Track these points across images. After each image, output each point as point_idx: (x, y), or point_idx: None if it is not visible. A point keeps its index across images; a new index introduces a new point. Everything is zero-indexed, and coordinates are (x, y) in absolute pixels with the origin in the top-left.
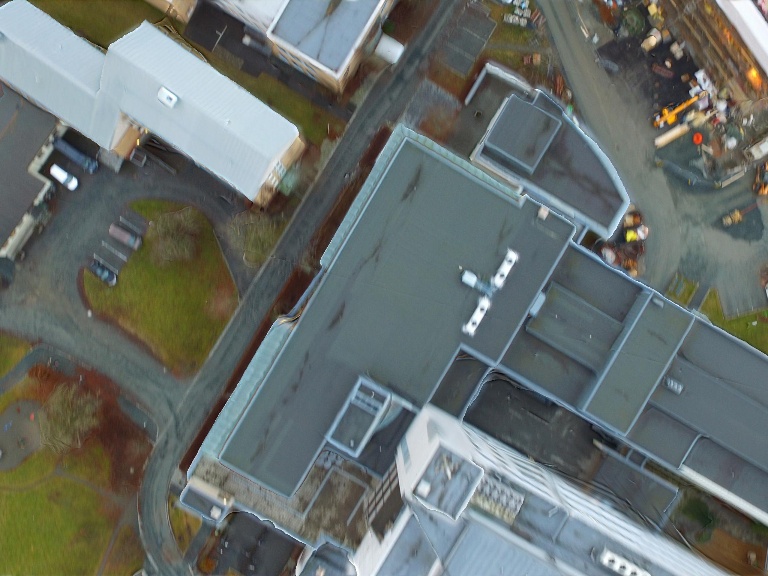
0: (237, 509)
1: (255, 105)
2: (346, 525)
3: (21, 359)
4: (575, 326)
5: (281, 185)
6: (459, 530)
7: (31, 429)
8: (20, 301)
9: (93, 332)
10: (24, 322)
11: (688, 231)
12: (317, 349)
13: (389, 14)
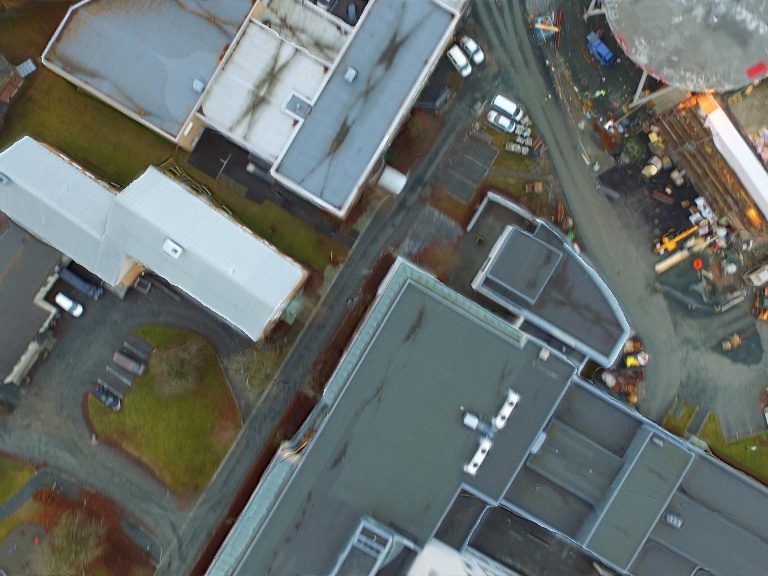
0: None
1: (259, 249)
2: None
3: (26, 483)
4: (575, 461)
5: (284, 314)
6: None
7: (35, 552)
8: (25, 425)
9: (97, 456)
10: (29, 446)
11: (688, 355)
12: (320, 488)
13: (392, 142)
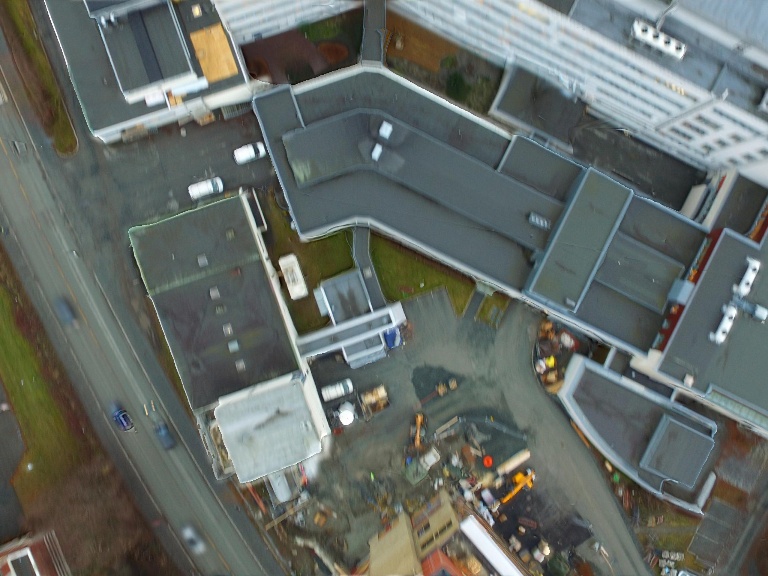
0: None
1: None
2: None
3: None
4: (636, 272)
5: None
6: None
7: None
8: None
9: None
10: None
11: (489, 371)
12: None
13: None
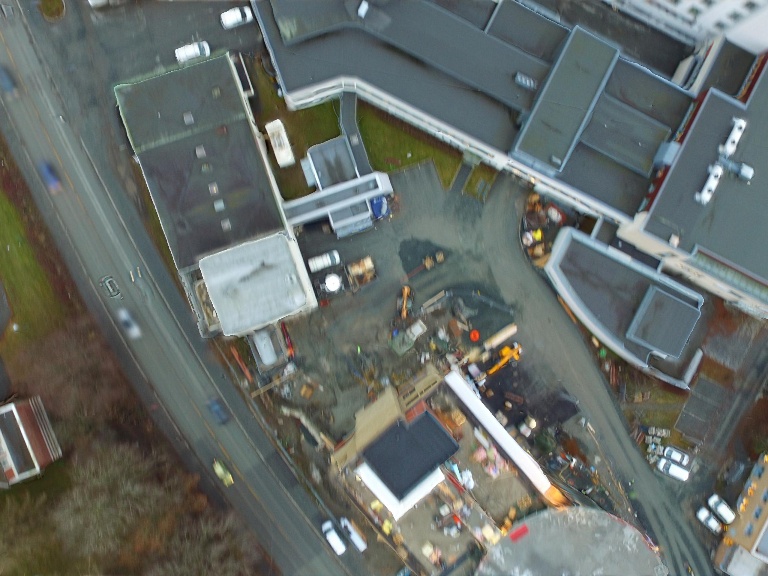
0: None
1: None
2: None
3: None
4: (623, 135)
5: None
6: None
7: None
8: None
9: None
10: None
11: (476, 245)
12: None
13: None
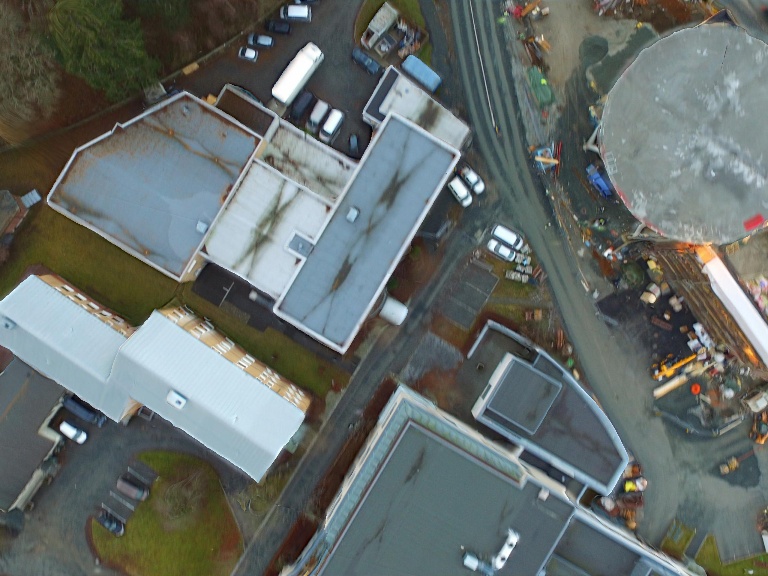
0: None
1: (262, 392)
2: None
3: None
4: None
5: None
6: None
7: None
8: (29, 550)
9: None
10: (33, 570)
11: (686, 478)
12: None
13: None
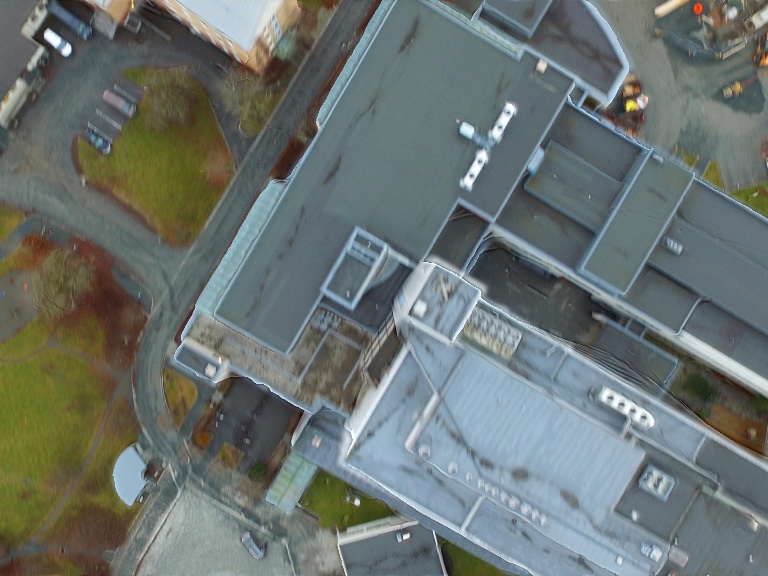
0: (232, 372)
1: None
2: (342, 389)
3: (14, 228)
4: (574, 186)
5: (277, 49)
6: (456, 359)
7: (24, 299)
8: (13, 170)
9: (87, 202)
10: (17, 191)
11: (688, 103)
12: (313, 203)
13: None
